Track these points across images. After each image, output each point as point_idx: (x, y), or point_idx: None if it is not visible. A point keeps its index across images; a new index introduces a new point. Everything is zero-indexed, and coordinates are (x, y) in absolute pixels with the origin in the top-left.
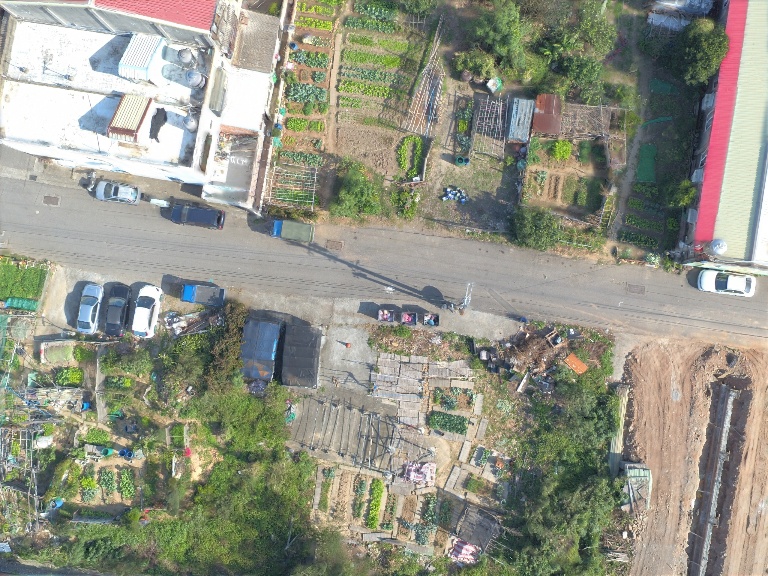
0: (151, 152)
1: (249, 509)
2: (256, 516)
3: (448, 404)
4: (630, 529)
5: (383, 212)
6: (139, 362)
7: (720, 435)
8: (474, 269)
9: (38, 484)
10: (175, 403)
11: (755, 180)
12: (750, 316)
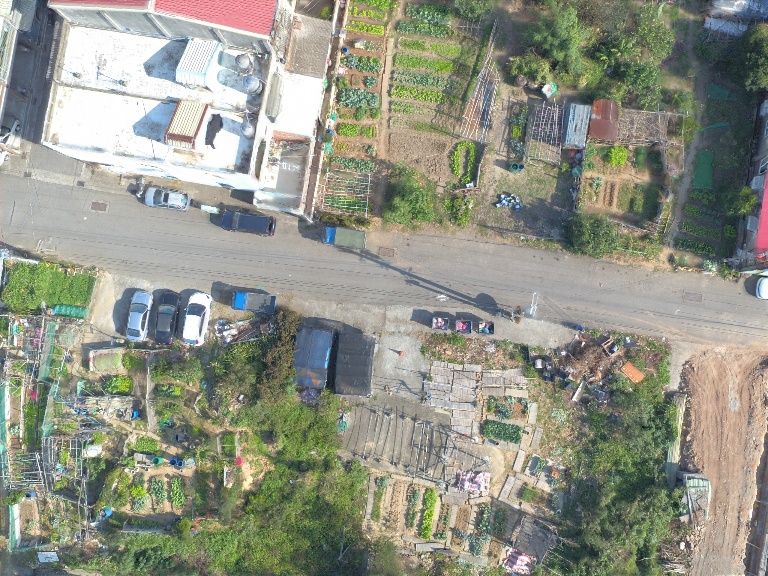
0: (207, 159)
1: (301, 519)
2: (308, 526)
3: (502, 413)
4: (688, 540)
5: (436, 219)
6: (191, 370)
7: None
8: (528, 276)
9: (87, 493)
10: (226, 412)
11: None
12: None
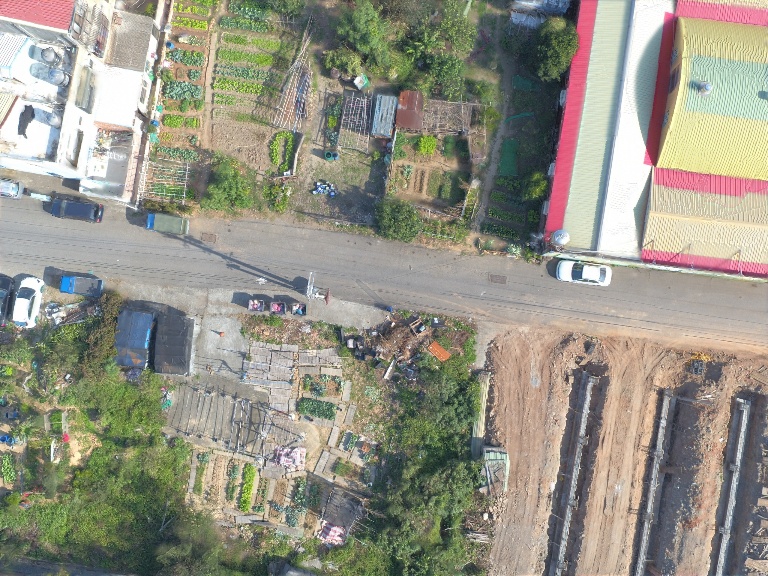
0: (19, 148)
1: (126, 493)
2: (132, 499)
3: (317, 391)
4: (490, 511)
5: (255, 205)
6: (16, 351)
7: (580, 420)
8: (343, 260)
9: None
10: (53, 390)
11: (601, 173)
12: (607, 305)
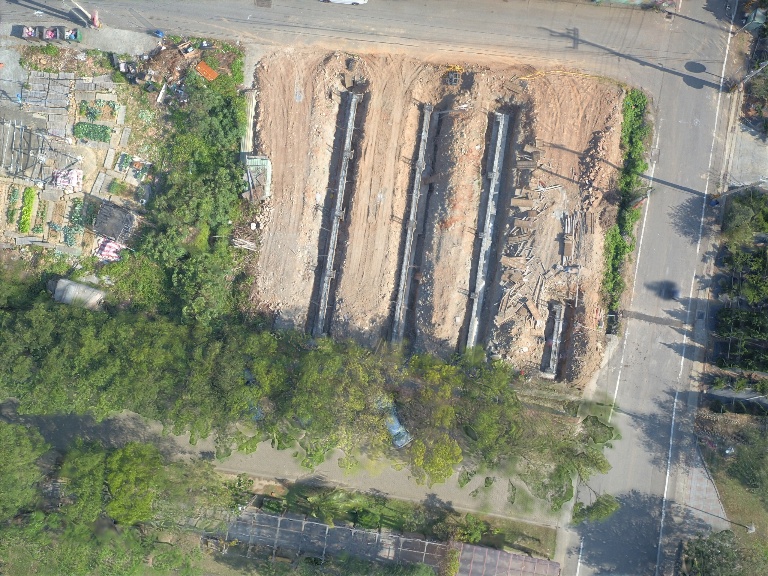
0: None
1: None
2: None
3: (91, 114)
4: (258, 220)
5: None
6: None
7: (346, 136)
8: None
9: None
10: None
11: None
12: (367, 23)
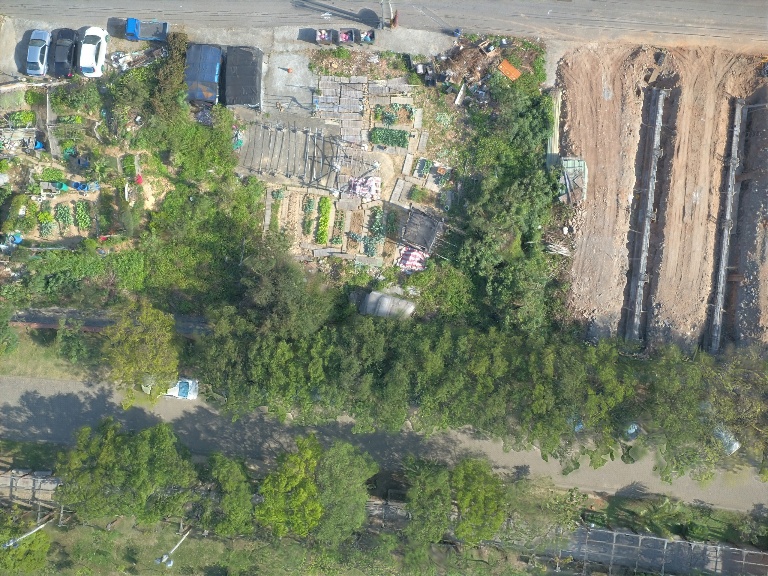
0: None
1: (202, 232)
2: (209, 239)
3: (389, 118)
4: (570, 224)
5: None
6: (87, 90)
7: (653, 134)
8: None
9: None
10: (125, 133)
11: None
12: (675, 15)
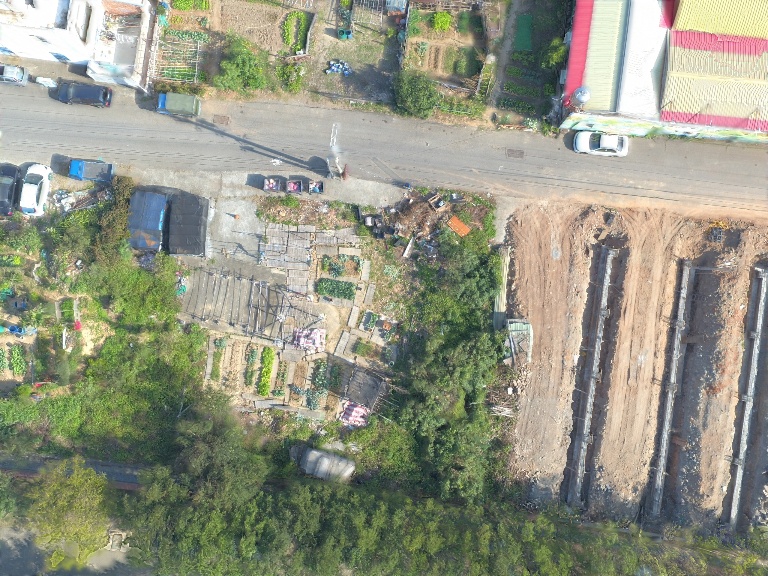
0: (27, 18)
1: (141, 380)
2: (148, 387)
3: (335, 270)
4: (515, 385)
5: (268, 86)
6: (25, 235)
7: (601, 293)
8: (358, 139)
9: None
10: (64, 277)
11: (618, 35)
12: (625, 176)
